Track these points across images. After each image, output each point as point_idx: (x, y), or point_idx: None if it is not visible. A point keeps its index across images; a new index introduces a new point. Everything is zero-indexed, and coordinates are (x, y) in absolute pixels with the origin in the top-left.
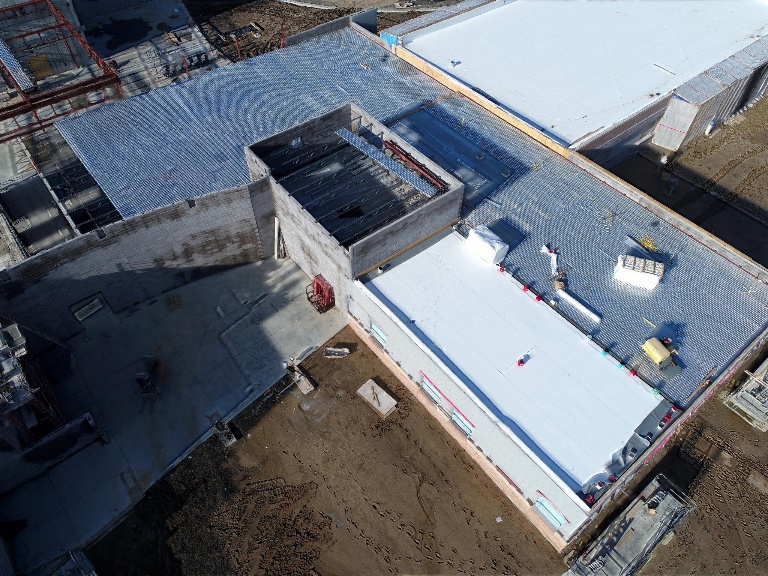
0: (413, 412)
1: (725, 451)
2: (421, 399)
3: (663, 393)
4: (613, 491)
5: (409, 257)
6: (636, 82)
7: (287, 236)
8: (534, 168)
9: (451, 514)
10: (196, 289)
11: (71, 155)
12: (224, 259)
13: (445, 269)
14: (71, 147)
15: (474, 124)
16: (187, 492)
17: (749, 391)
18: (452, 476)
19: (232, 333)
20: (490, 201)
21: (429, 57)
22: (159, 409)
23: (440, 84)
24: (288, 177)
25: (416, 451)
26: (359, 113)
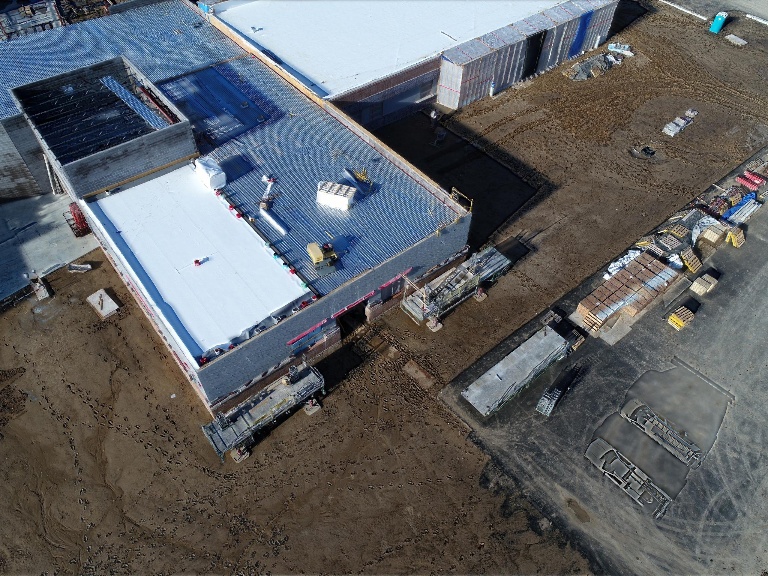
0: (131, 315)
1: (393, 346)
2: (139, 304)
3: (312, 287)
4: (228, 356)
5: (139, 183)
6: (418, 47)
7: (55, 171)
8: (289, 115)
9: (133, 392)
10: None
11: None
12: None
13: (167, 193)
14: None
15: (253, 80)
16: None
17: (420, 296)
18: (145, 363)
19: None
20: (236, 141)
21: (235, 24)
22: None
23: (239, 47)
24: (39, 114)
25: (122, 345)
26: (128, 64)
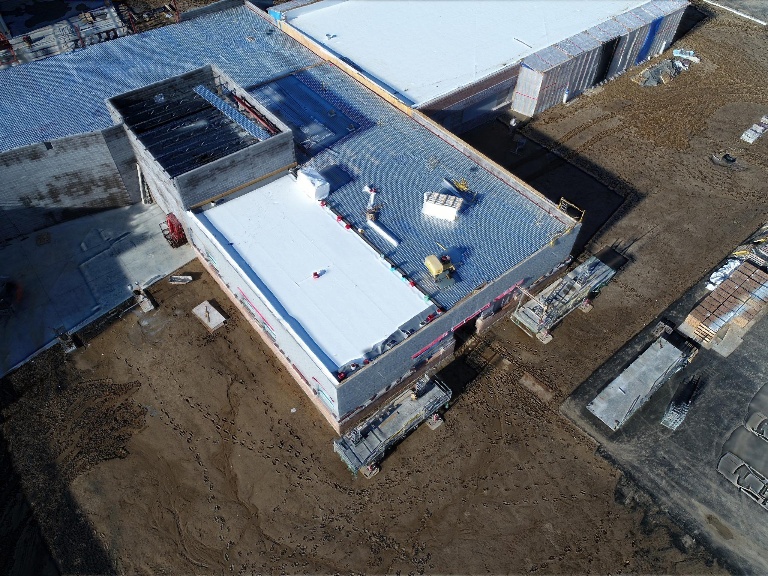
0: (239, 327)
1: (506, 358)
2: (246, 316)
3: (434, 300)
4: (365, 371)
5: (242, 194)
6: (494, 54)
7: (148, 181)
8: (378, 124)
9: (253, 406)
10: (66, 228)
11: None
12: (92, 202)
13: (272, 203)
14: None
15: (335, 88)
16: (25, 388)
17: (531, 308)
18: (261, 377)
19: (90, 264)
20: (330, 150)
21: (308, 31)
22: (12, 324)
23: (315, 55)
24: (139, 124)
25: (234, 358)
26: (218, 73)
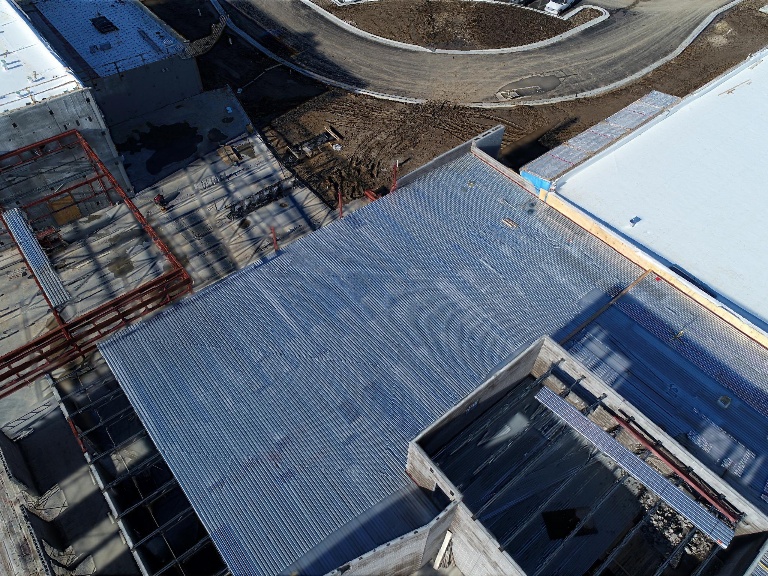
0: None
1: None
2: None
3: None
4: None
5: None
6: None
7: (463, 555)
8: None
9: None
10: None
11: (127, 410)
12: None
13: None
14: (127, 396)
15: (692, 333)
16: None
17: None
18: None
19: None
20: None
21: (595, 210)
22: None
23: (618, 253)
24: None
25: None
26: (560, 354)
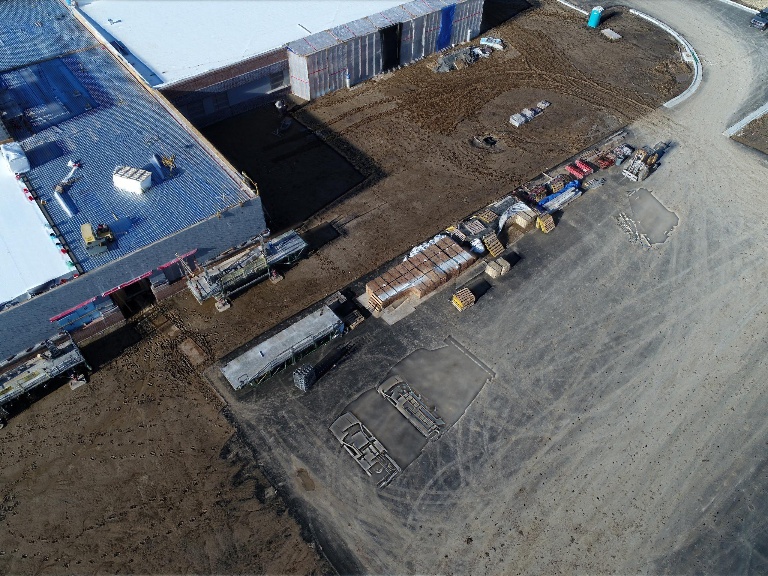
0: None
1: (176, 325)
2: None
3: (79, 266)
4: None
5: None
6: (270, 39)
7: None
8: (119, 104)
9: None
10: None
11: None
12: None
13: None
14: None
15: (95, 70)
16: None
17: None
18: None
19: None
20: (56, 128)
21: (95, 16)
22: None
23: (95, 39)
24: None
25: None
26: None
